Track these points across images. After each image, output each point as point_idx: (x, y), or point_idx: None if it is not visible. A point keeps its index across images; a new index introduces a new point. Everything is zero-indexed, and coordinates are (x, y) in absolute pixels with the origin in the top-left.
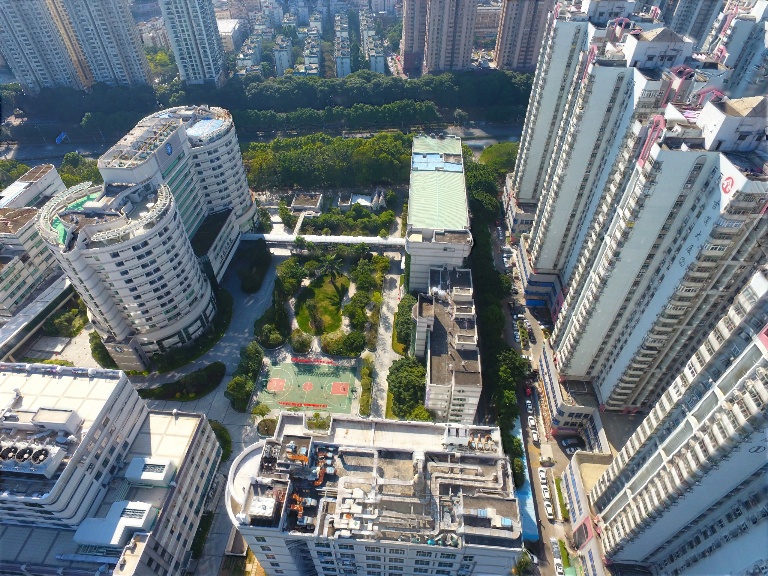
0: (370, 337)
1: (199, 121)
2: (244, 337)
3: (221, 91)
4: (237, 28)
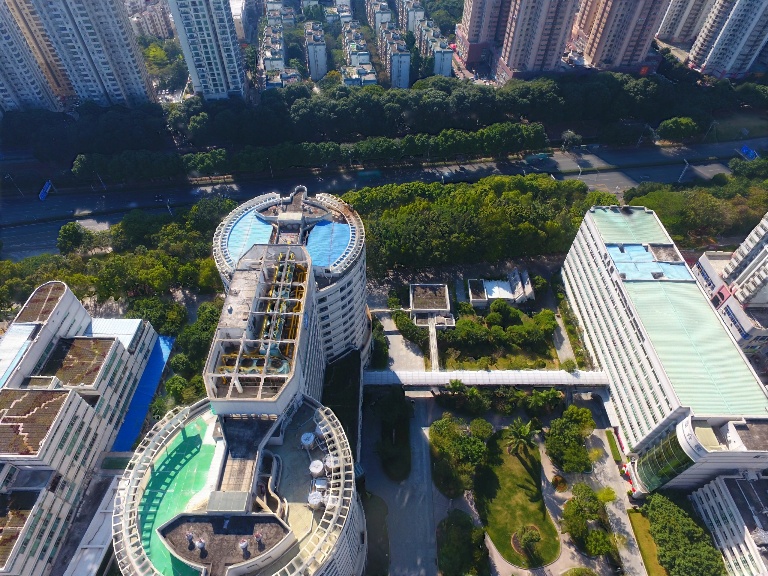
0: (618, 573)
1: (312, 229)
2: None
3: (258, 112)
4: (244, 7)
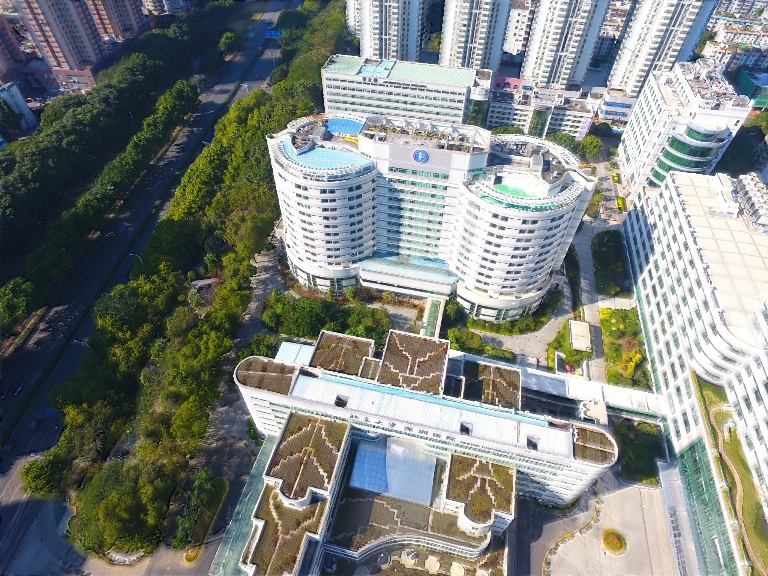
0: None
1: None
2: None
3: None
4: None
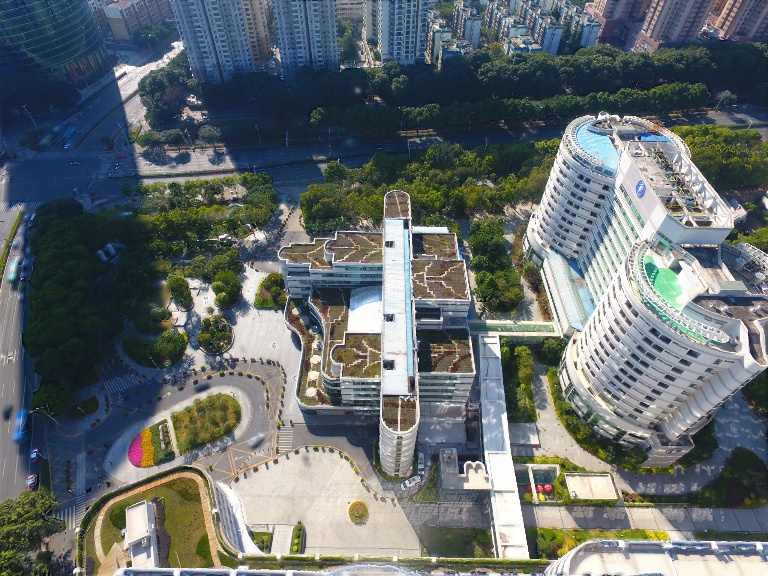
0: None
1: (640, 138)
2: (737, 409)
3: (453, 74)
4: None
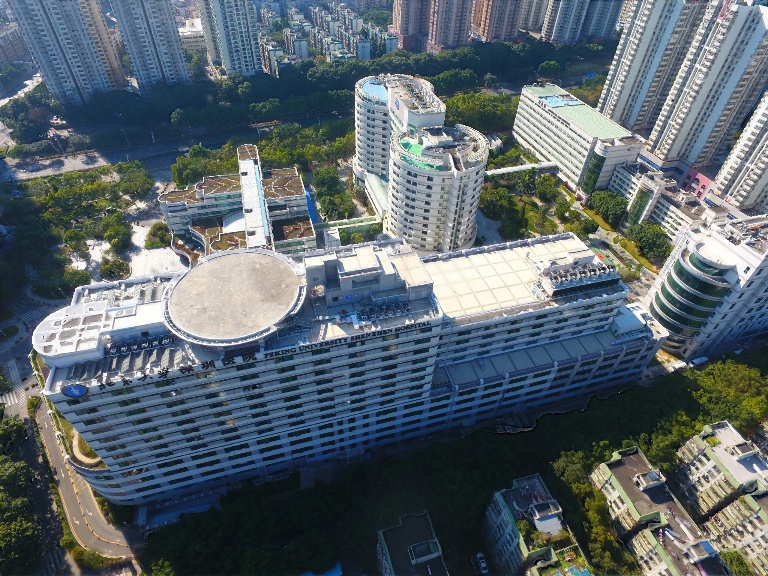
0: None
1: None
2: None
3: (287, 78)
4: None
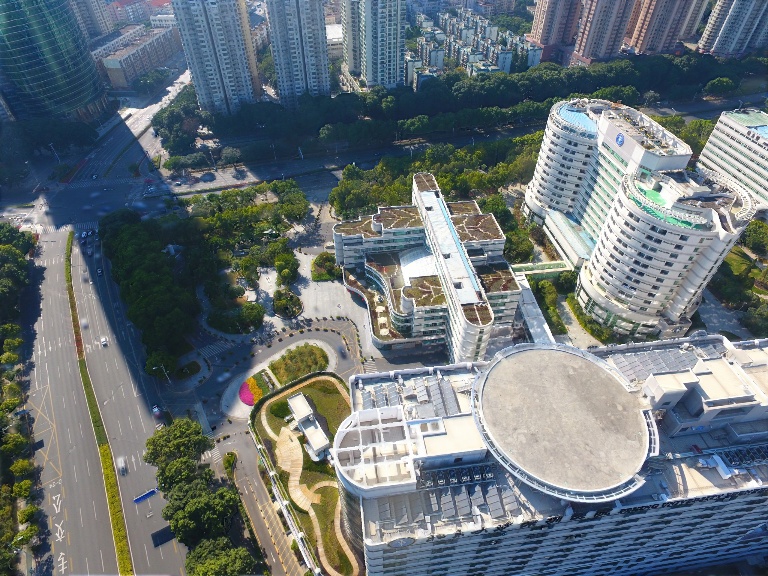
0: None
1: None
2: (713, 307)
3: (432, 92)
4: None
